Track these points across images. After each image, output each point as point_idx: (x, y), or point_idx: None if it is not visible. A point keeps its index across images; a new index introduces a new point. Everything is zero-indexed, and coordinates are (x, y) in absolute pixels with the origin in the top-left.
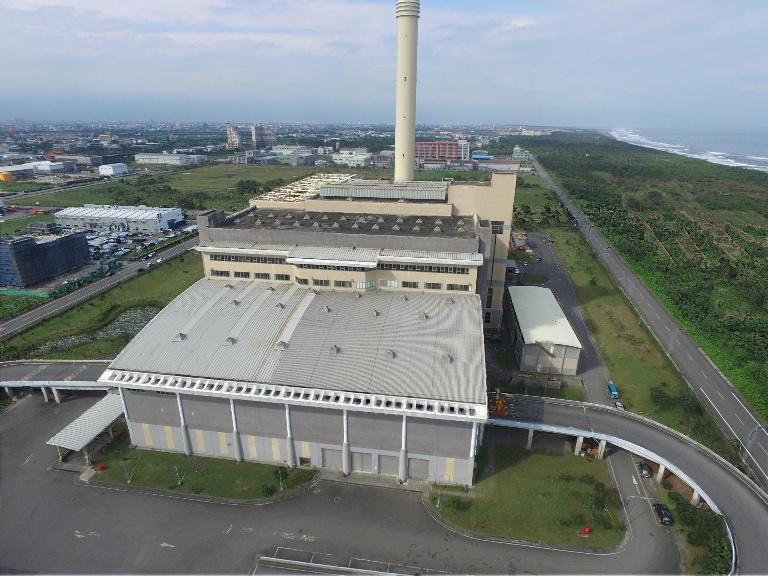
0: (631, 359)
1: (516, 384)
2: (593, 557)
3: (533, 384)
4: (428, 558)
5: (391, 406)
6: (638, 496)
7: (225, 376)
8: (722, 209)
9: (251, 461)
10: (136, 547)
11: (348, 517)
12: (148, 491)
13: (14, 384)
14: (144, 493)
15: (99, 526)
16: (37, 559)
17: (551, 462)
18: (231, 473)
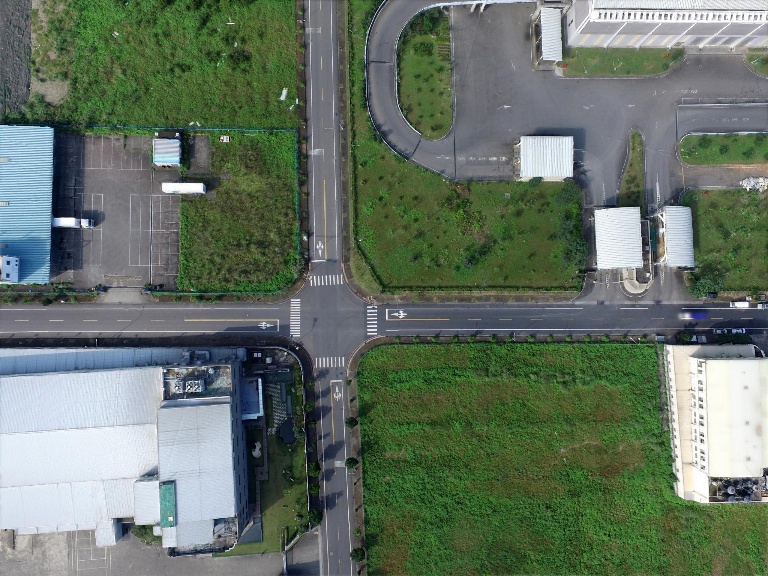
0: None
1: None
2: None
3: None
4: (751, 93)
5: None
6: None
7: (674, 7)
8: None
9: (645, 47)
10: (618, 109)
11: (710, 77)
12: (601, 77)
13: (455, 4)
14: (599, 79)
15: (592, 101)
16: (578, 122)
17: None
18: (638, 58)
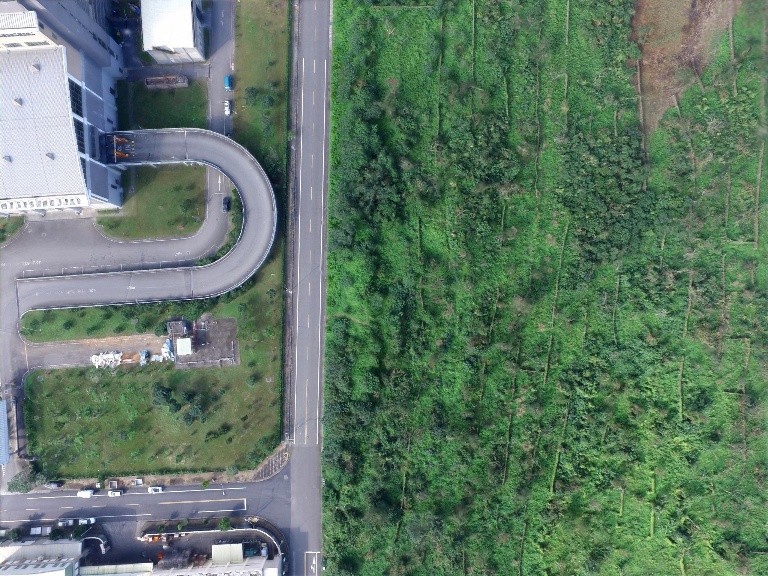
0: (258, 23)
1: (152, 89)
2: (183, 241)
3: (165, 88)
4: (101, 260)
5: (27, 207)
6: (218, 193)
7: None
8: None
9: None
10: None
11: (54, 245)
12: None
13: None
14: None
15: None
16: None
17: (170, 177)
18: None
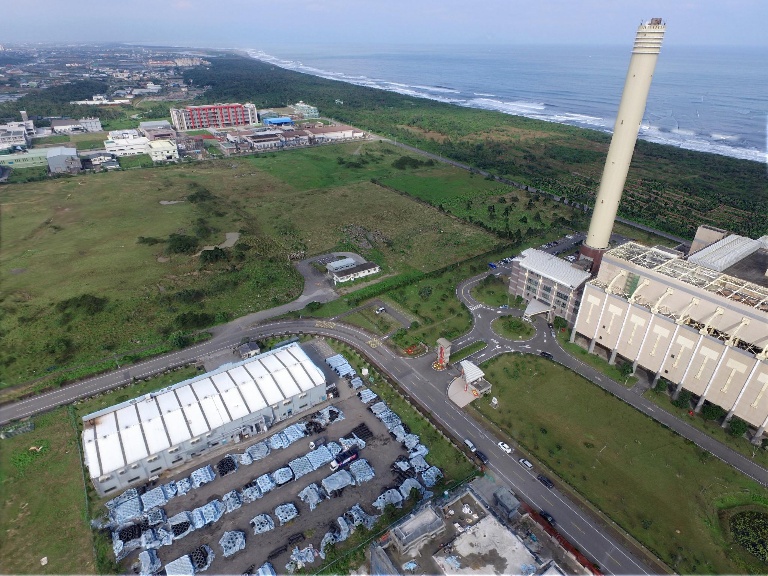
0: None
1: None
2: None
3: None
4: None
5: None
6: None
7: None
8: (574, 163)
9: None
10: None
11: None
12: None
13: None
14: None
15: None
16: None
17: None
18: None
